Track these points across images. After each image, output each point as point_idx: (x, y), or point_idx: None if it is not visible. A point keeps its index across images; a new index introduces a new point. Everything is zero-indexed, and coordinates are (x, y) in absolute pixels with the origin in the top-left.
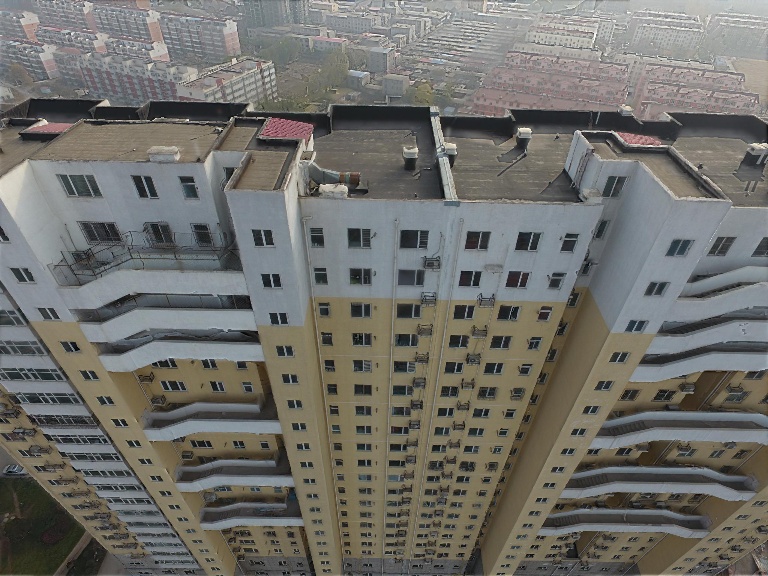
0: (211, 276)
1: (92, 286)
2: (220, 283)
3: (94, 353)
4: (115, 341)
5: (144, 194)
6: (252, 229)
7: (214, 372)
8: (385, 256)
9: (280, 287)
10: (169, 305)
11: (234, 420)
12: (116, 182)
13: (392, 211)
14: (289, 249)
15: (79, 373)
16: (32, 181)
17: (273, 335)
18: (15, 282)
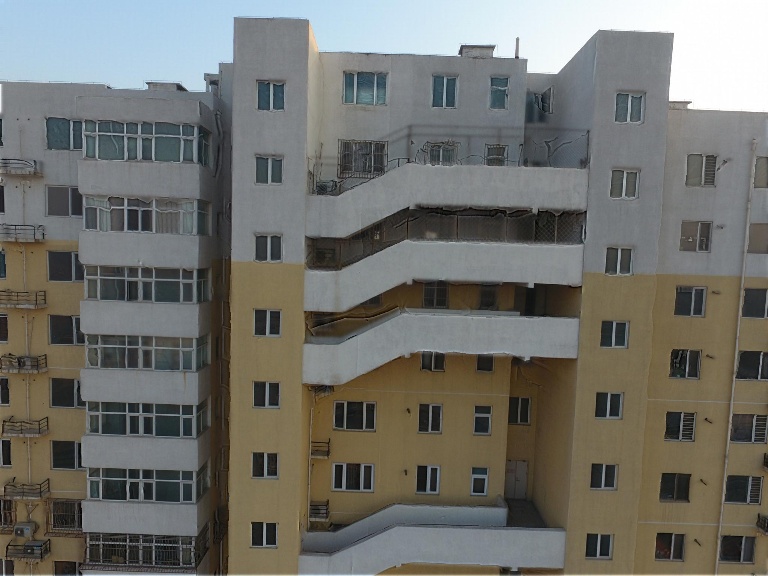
0: (540, 173)
1: (359, 191)
2: (550, 186)
3: (301, 336)
4: (346, 308)
5: (439, 102)
6: (617, 93)
7: (433, 440)
8: (734, 199)
9: (632, 198)
10: (455, 236)
11: (479, 526)
12: (412, 83)
13: (747, 128)
14: (662, 124)
15: (251, 388)
16: (320, 67)
17: (604, 295)
18: (252, 181)
